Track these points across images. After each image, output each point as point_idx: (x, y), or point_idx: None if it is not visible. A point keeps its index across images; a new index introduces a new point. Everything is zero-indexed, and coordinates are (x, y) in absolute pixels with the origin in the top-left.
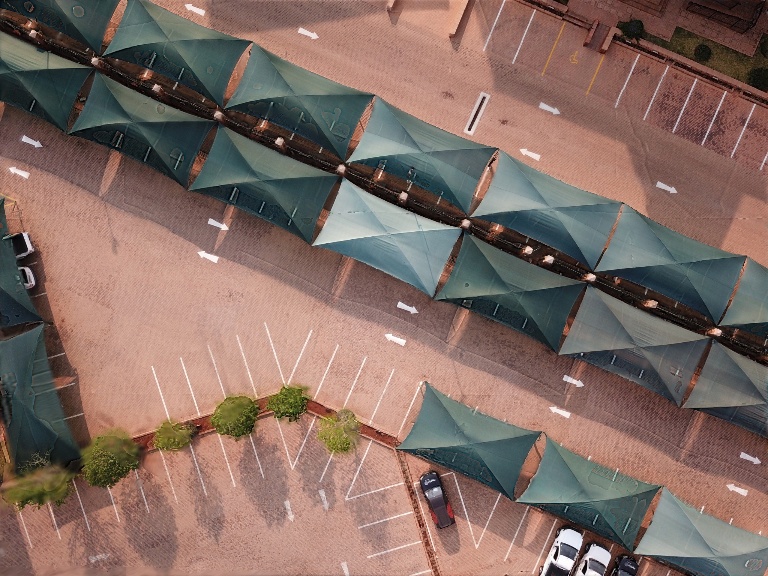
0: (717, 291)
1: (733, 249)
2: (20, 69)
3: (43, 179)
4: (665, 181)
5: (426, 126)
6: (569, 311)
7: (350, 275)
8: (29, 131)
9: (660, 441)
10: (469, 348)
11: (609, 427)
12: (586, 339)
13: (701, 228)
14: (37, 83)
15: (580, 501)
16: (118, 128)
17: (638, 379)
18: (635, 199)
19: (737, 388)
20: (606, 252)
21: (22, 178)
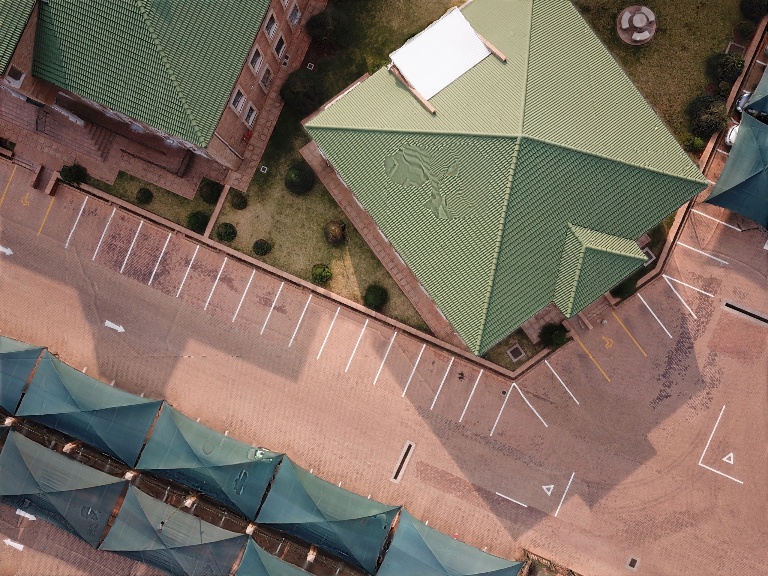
0: (128, 436)
1: (178, 387)
2: None
3: None
4: (113, 320)
5: None
6: None
7: None
8: None
9: (110, 574)
10: None
11: (60, 560)
12: (2, 482)
13: (147, 366)
14: None
15: None
16: None
17: (55, 521)
18: (84, 338)
19: (142, 532)
20: (24, 397)
21: None
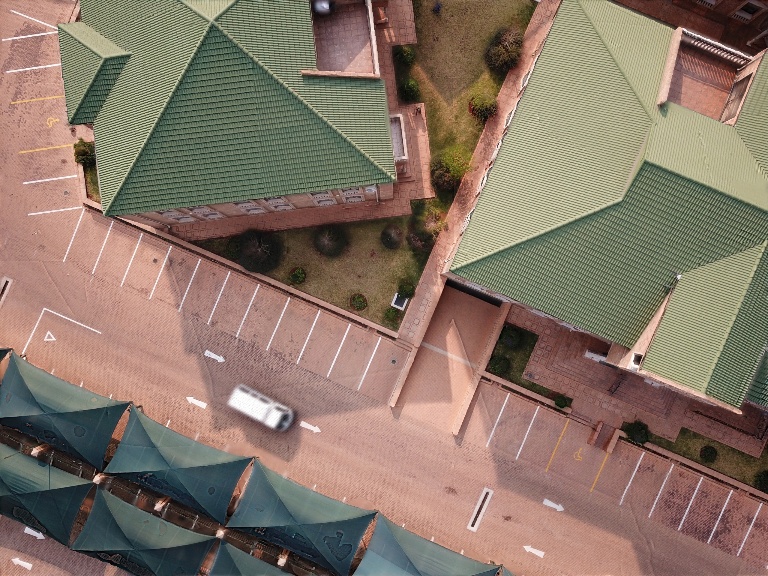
0: None
1: None
2: (22, 491)
3: (46, 571)
4: None
5: (429, 546)
6: None
7: None
8: (31, 523)
9: None
10: None
11: None
12: None
13: None
14: (39, 504)
15: None
16: (120, 554)
17: None
18: None
19: None
20: None
21: (25, 570)
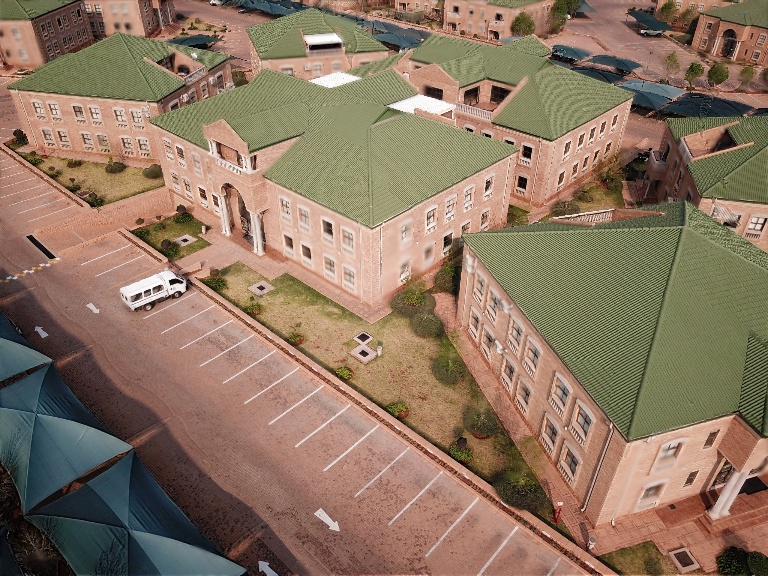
0: None
1: None
2: None
3: None
4: None
5: None
6: None
7: None
8: None
9: None
10: None
11: None
12: (562, 65)
13: None
14: None
15: None
16: None
17: None
18: None
19: None
20: None
21: None
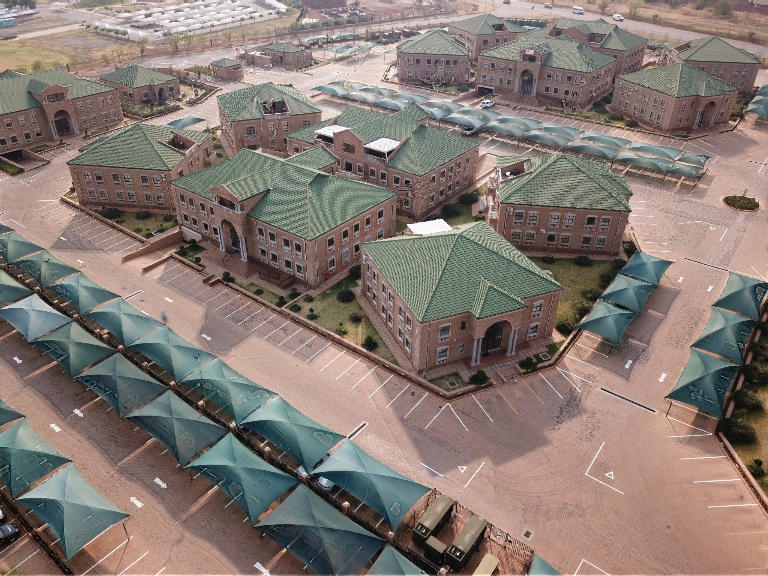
0: (186, 364)
1: None
2: None
3: None
4: None
5: None
6: (96, 360)
7: (3, 341)
8: None
9: (106, 458)
10: (33, 384)
11: (79, 442)
12: None
13: None
14: None
15: (5, 446)
16: None
17: (107, 397)
18: (185, 338)
19: None
20: None
21: None
